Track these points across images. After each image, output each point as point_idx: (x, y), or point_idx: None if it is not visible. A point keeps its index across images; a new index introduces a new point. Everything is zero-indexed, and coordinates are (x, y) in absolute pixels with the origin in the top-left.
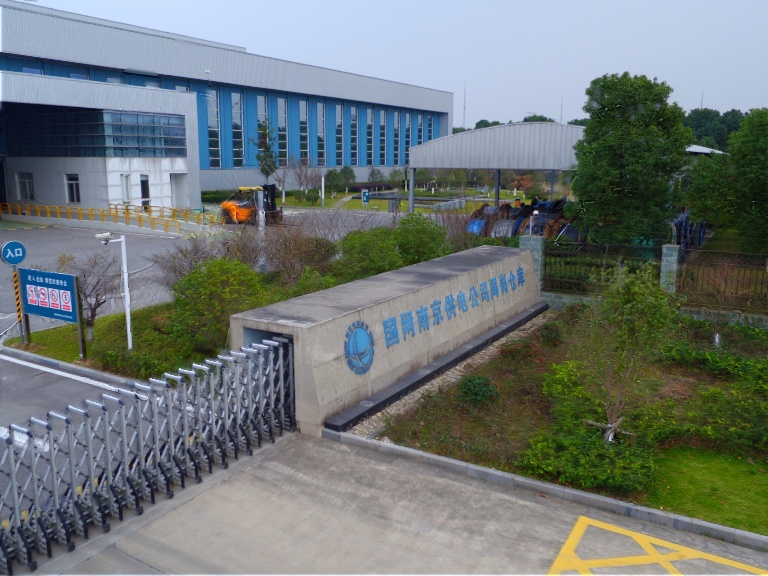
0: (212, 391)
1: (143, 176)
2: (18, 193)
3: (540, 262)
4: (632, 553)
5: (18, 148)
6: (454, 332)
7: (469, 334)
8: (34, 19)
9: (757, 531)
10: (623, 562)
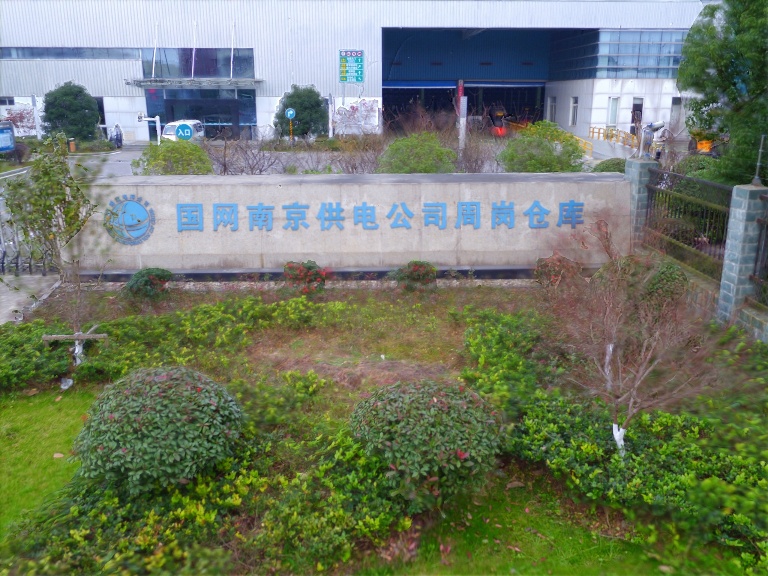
0: None
1: (637, 99)
2: (547, 116)
3: (636, 201)
4: None
5: None
6: (332, 247)
7: (374, 258)
8: None
9: None
10: None
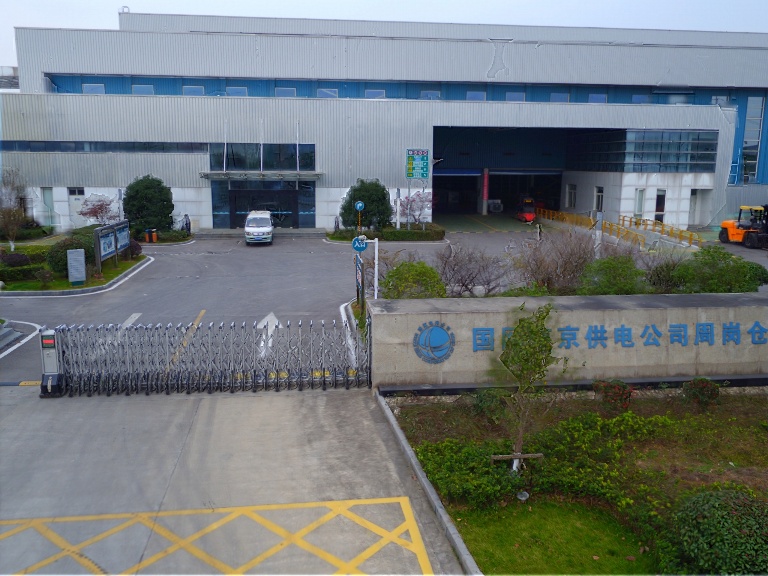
0: (300, 339)
1: (660, 191)
2: (566, 201)
3: None
4: (382, 525)
5: (574, 163)
6: (598, 362)
7: (630, 371)
8: (603, 51)
9: (486, 567)
10: (365, 524)
